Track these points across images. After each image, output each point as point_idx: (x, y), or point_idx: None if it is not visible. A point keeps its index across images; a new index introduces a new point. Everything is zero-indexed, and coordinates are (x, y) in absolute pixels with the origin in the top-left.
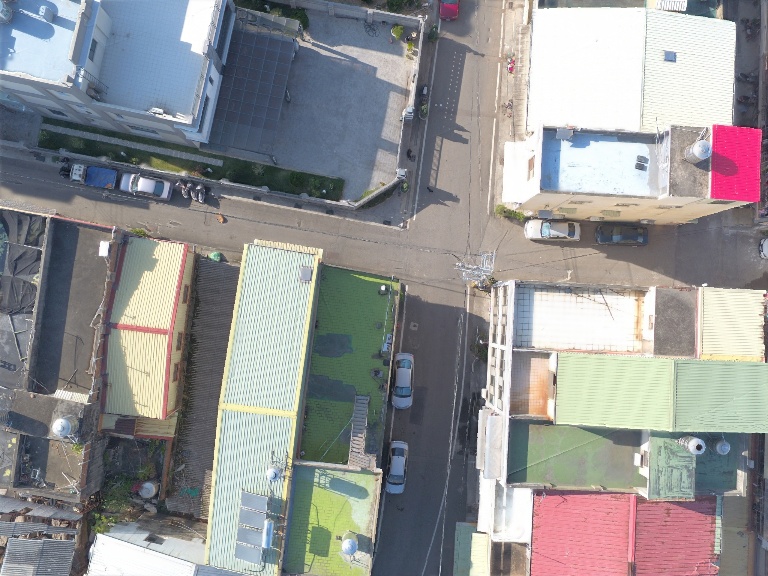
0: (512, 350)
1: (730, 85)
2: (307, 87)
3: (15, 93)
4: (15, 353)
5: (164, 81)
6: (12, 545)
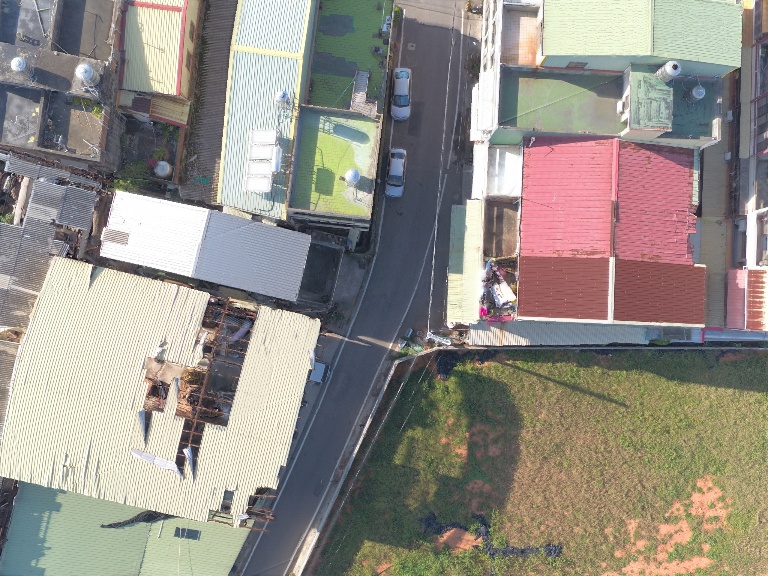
0: (502, 3)
1: None
2: None
3: None
4: (39, 30)
5: None
6: (37, 187)
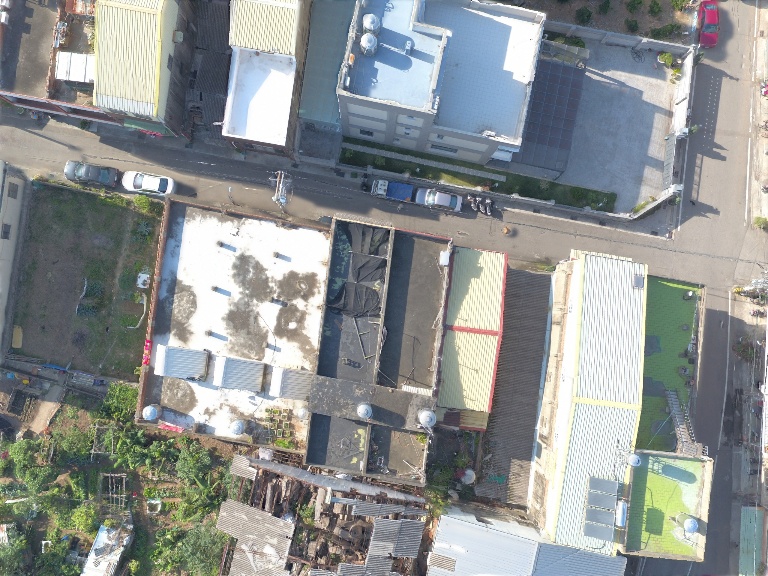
0: None
1: None
2: (580, 109)
3: (352, 117)
4: (359, 352)
5: (489, 106)
6: (378, 525)
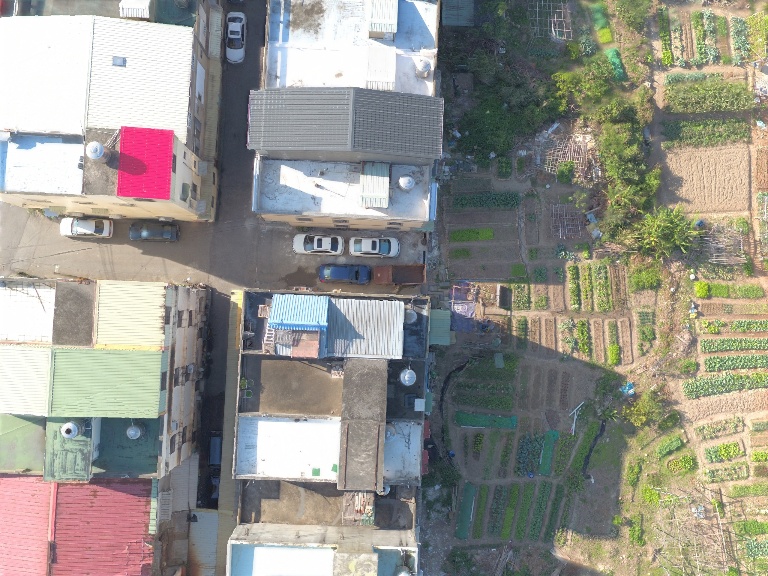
0: None
1: (186, 88)
2: None
3: None
4: None
5: None
6: None
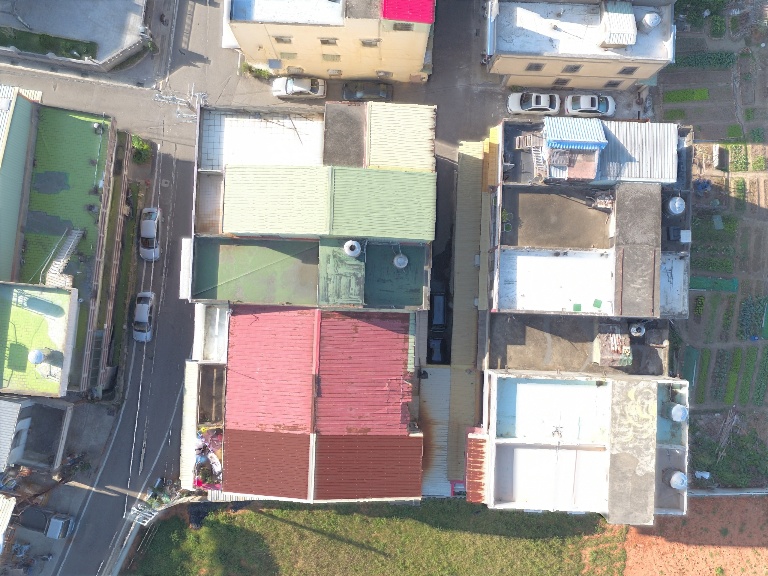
0: (197, 171)
1: None
2: None
3: None
4: None
5: None
6: None
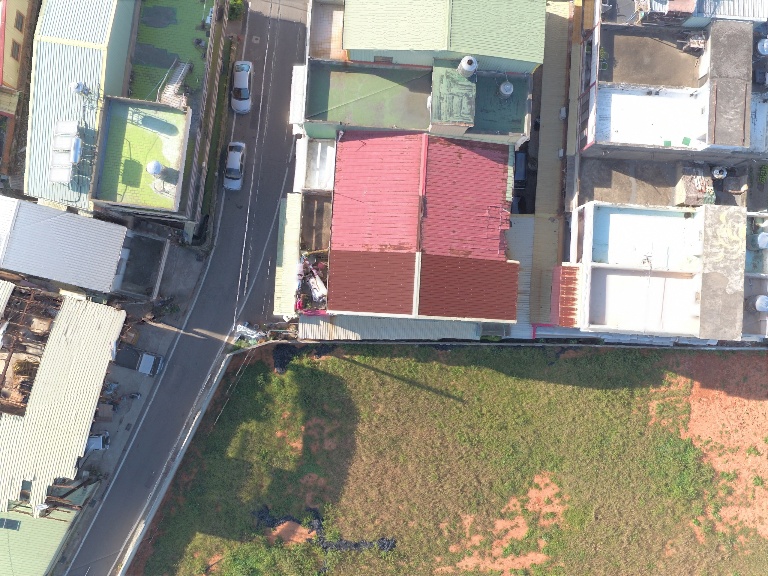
0: None
1: None
2: None
3: None
4: None
5: None
6: None
